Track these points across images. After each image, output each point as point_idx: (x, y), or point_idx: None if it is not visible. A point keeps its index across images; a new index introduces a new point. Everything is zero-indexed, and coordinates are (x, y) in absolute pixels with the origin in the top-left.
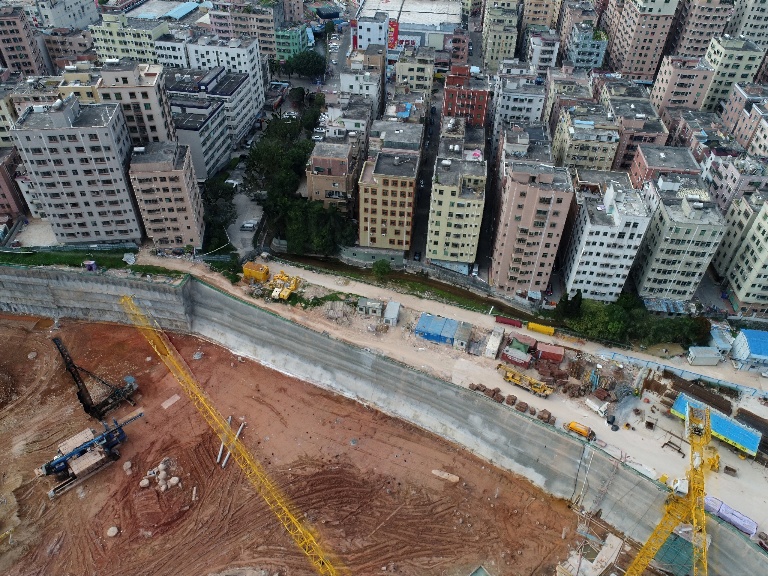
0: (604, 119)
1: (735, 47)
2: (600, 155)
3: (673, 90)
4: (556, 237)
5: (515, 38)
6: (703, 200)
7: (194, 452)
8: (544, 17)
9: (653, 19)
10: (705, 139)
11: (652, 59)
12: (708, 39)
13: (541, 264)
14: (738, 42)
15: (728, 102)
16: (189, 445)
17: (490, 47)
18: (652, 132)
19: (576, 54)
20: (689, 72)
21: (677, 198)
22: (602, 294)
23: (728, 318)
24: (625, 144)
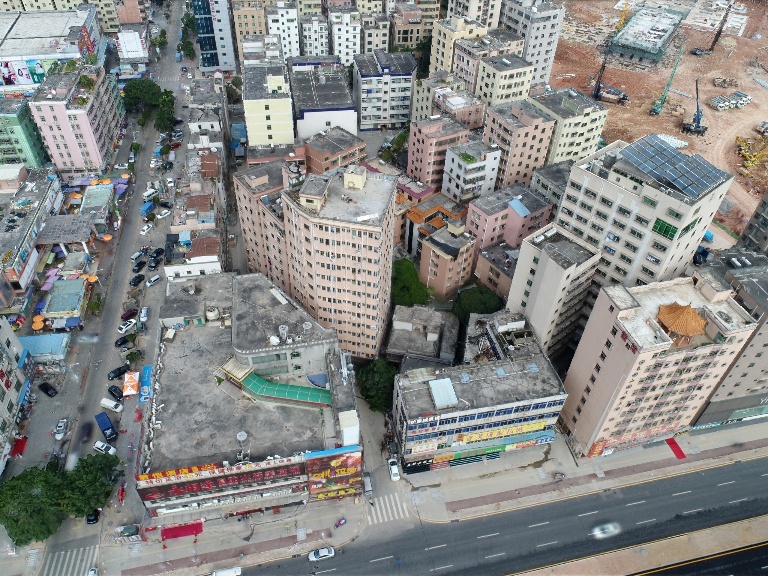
0: None
1: None
2: None
3: None
4: None
5: None
6: None
7: (577, 81)
8: None
9: None
10: None
11: None
12: None
13: None
14: None
15: None
16: (576, 83)
17: (114, 8)
18: None
19: None
20: None
21: None
22: None
23: None
24: None
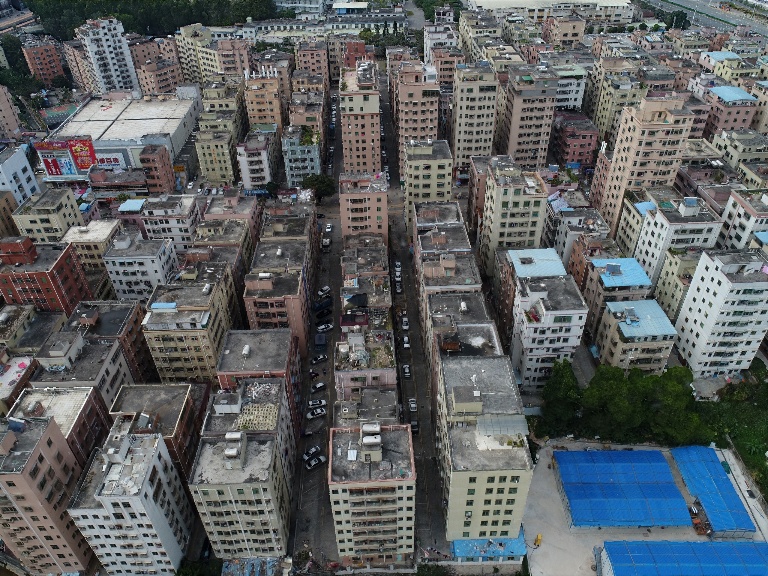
0: (200, 293)
1: (424, 154)
2: (192, 344)
3: (349, 216)
4: (45, 519)
5: (226, 147)
6: (264, 427)
7: None
8: (271, 115)
9: (358, 119)
10: (355, 291)
11: (372, 160)
12: (424, 134)
13: (53, 546)
14: (425, 148)
15: (413, 224)
16: None
17: (201, 158)
18: (281, 294)
19: (287, 162)
20: (358, 196)
21: (225, 431)
22: (151, 573)
23: (337, 574)
24: (252, 311)
